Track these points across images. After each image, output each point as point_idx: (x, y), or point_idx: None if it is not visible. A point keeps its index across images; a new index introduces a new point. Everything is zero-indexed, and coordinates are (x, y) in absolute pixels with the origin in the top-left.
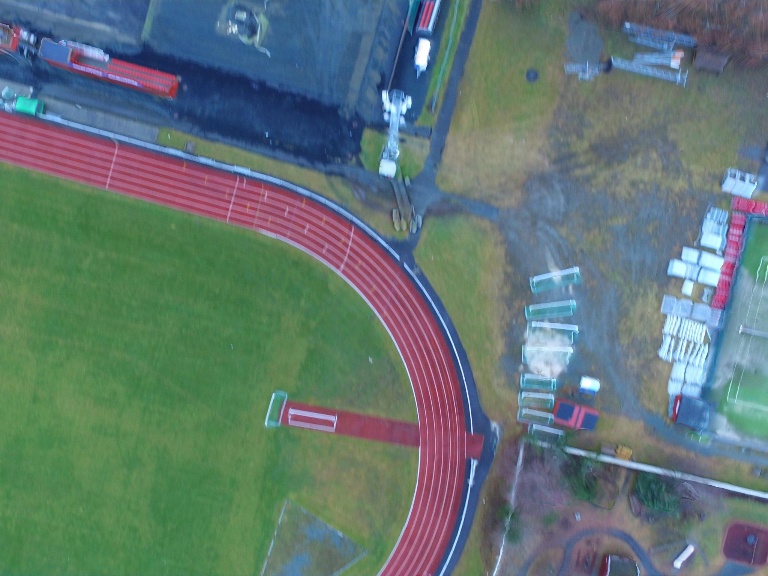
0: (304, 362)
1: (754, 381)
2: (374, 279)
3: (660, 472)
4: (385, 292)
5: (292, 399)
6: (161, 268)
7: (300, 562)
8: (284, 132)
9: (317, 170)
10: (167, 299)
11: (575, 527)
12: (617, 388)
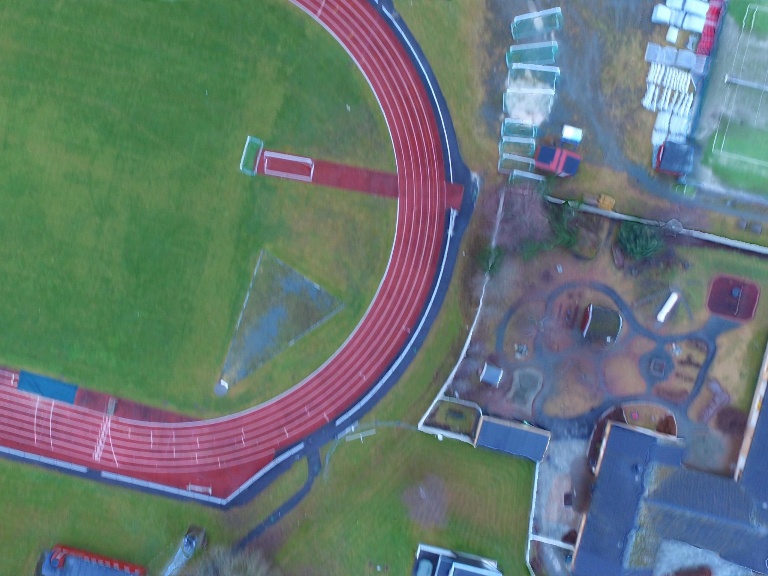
0: (280, 109)
1: (740, 132)
2: (352, 25)
3: (643, 222)
4: (363, 38)
5: (268, 148)
6: (134, 12)
7: (276, 315)
8: None
9: None
10: (140, 43)
11: (557, 280)
12: (600, 138)
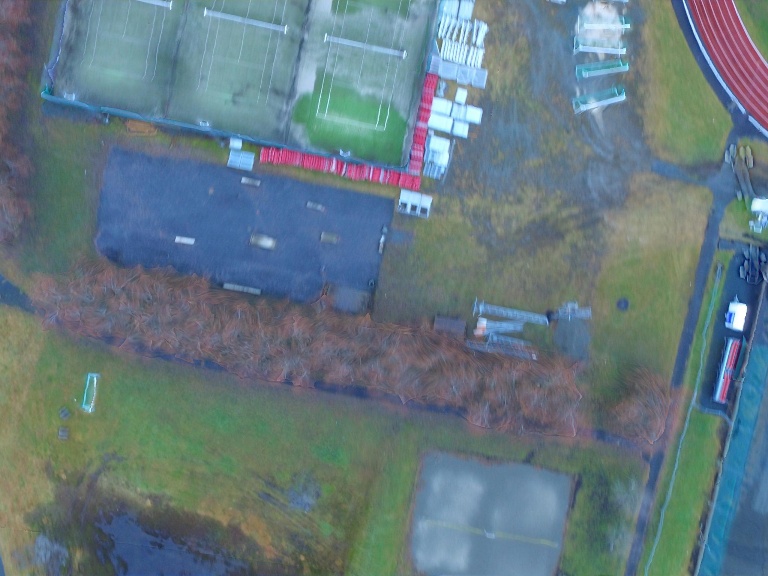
0: None
1: (388, 1)
2: None
3: None
4: (759, 85)
5: None
6: None
7: None
8: None
9: None
10: None
11: None
12: None
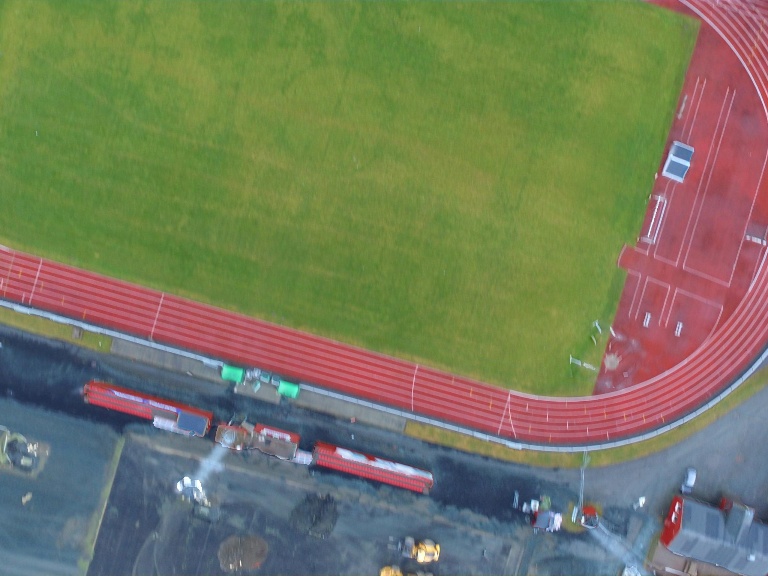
0: None
1: None
2: None
3: None
4: None
5: None
6: (110, 214)
7: None
8: None
9: None
10: (104, 183)
11: None
12: None
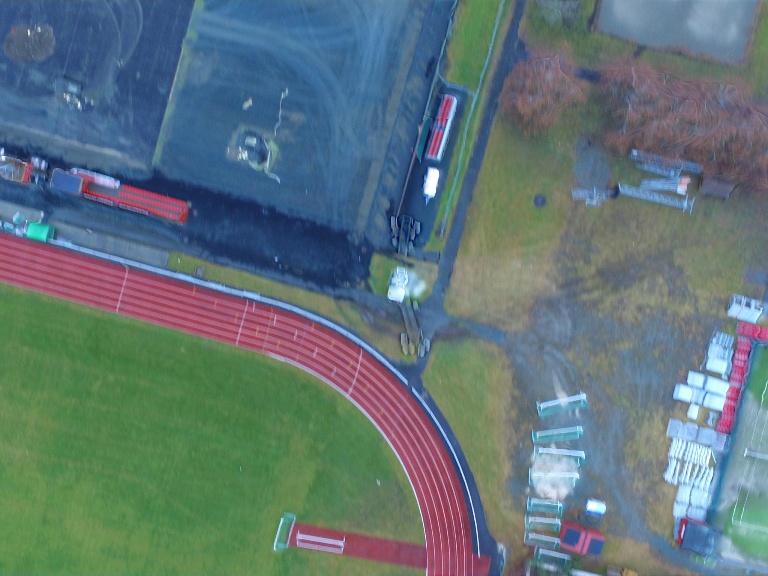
0: (312, 484)
1: (759, 503)
2: (382, 402)
3: None
4: (393, 415)
5: (300, 521)
6: (170, 391)
7: None
8: (293, 257)
9: (326, 294)
10: (176, 422)
11: None
12: (623, 510)
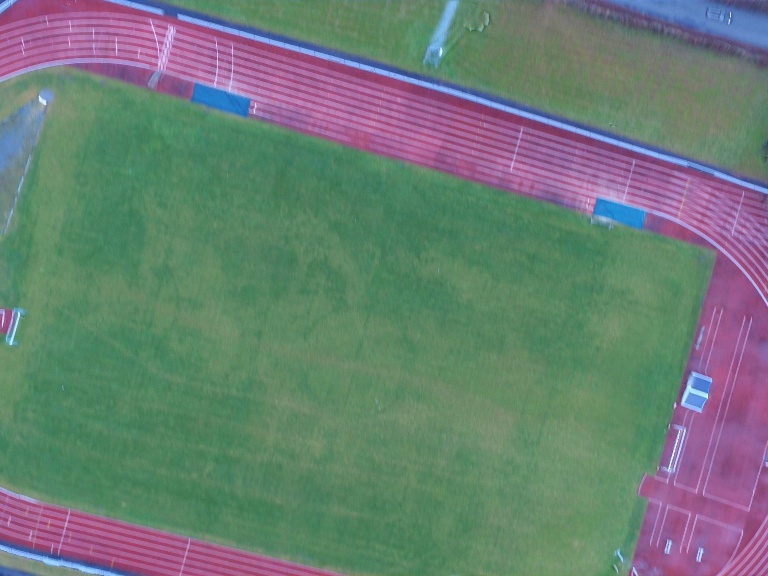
0: None
1: None
2: None
3: None
4: None
5: (2, 335)
6: (136, 464)
7: None
8: None
9: None
10: (130, 434)
11: None
12: None
